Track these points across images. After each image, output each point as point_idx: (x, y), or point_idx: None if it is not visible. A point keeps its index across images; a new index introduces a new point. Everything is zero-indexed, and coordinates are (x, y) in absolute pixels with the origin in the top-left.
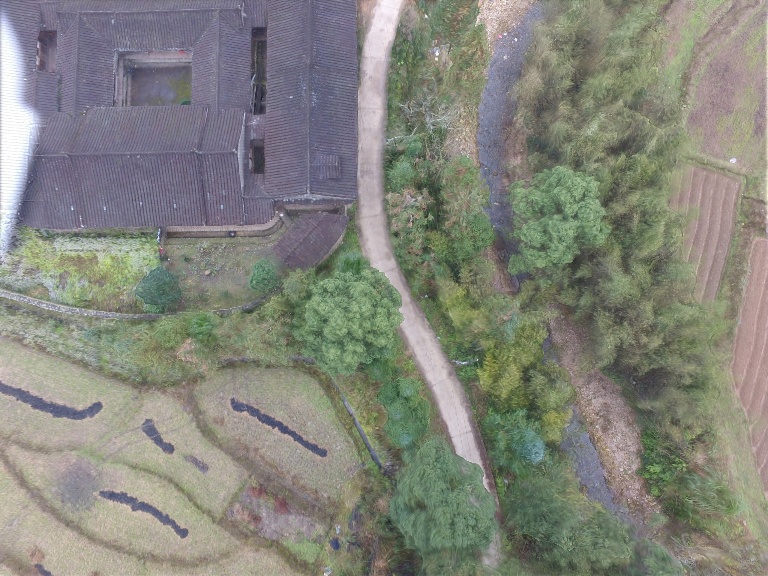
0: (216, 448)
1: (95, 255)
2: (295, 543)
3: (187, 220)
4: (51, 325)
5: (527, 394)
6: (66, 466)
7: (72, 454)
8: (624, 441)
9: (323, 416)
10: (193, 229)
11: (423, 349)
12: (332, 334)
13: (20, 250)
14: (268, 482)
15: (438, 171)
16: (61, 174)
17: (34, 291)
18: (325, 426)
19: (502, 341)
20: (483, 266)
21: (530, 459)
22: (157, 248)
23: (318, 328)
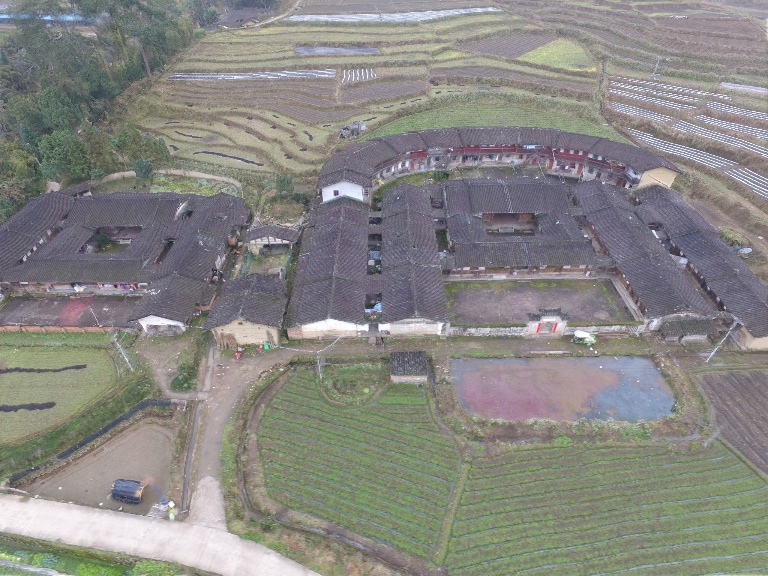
0: None
1: None
2: None
3: None
4: None
5: None
6: None
7: None
8: None
9: None
10: None
11: None
12: None
13: None
14: None
15: None
16: None
17: None
18: None
19: None
20: None
21: None
22: None
23: None
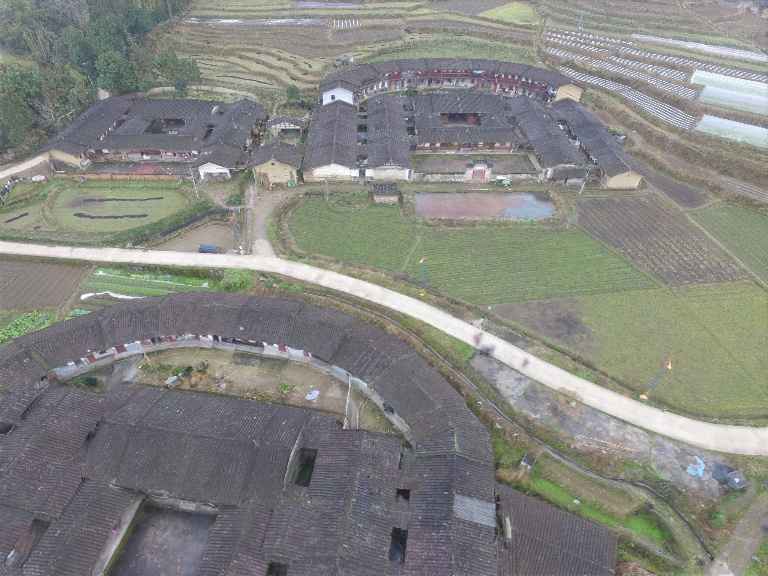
0: None
1: None
2: None
3: None
4: None
5: None
6: None
7: None
8: None
9: None
10: None
11: (105, 94)
12: None
13: None
14: None
15: None
16: None
17: None
18: None
19: None
20: None
21: None
22: None
23: None
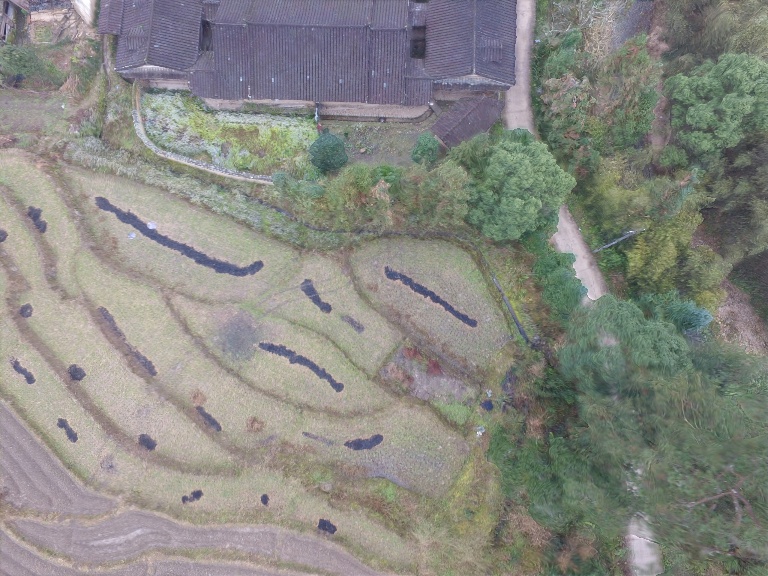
0: (372, 310)
1: (256, 128)
2: (446, 404)
3: (350, 96)
4: (215, 188)
5: (679, 277)
6: (228, 317)
7: (234, 306)
8: (751, 350)
9: (474, 289)
10: (345, 113)
11: (565, 239)
12: (516, 186)
13: (185, 119)
14: (421, 346)
15: (595, 63)
16: (235, 44)
17: (198, 157)
18: (476, 298)
19: (657, 224)
20: (637, 154)
21: (697, 324)
22: (314, 126)
23: (500, 181)
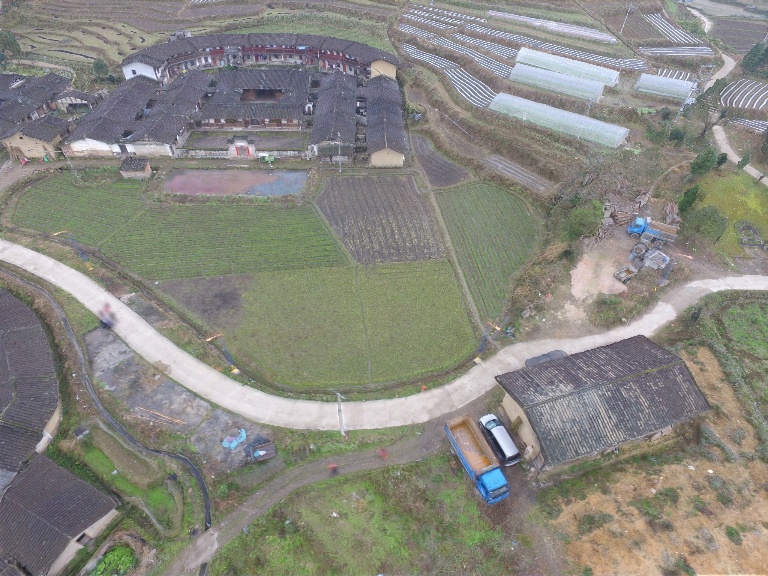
0: None
1: None
2: None
3: None
4: None
5: None
6: None
7: None
8: None
9: None
10: None
11: None
12: None
13: None
14: None
15: None
16: None
17: None
18: None
19: None
20: None
21: None
22: None
23: None
